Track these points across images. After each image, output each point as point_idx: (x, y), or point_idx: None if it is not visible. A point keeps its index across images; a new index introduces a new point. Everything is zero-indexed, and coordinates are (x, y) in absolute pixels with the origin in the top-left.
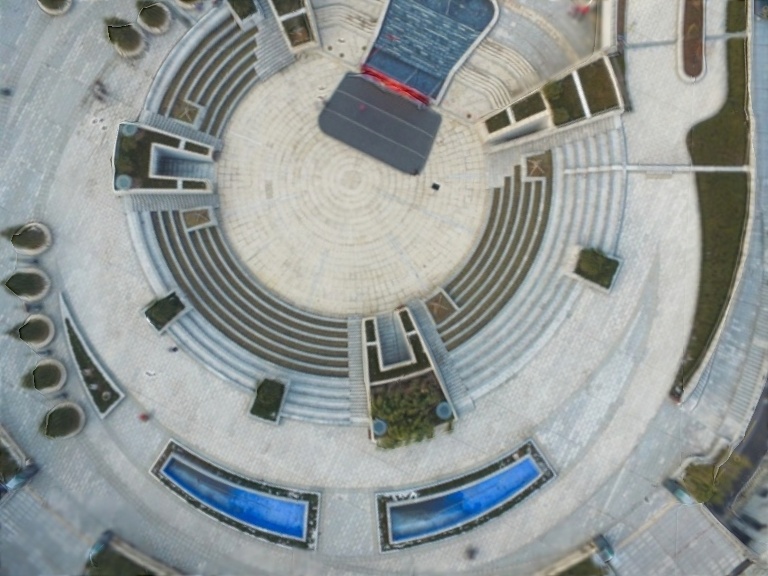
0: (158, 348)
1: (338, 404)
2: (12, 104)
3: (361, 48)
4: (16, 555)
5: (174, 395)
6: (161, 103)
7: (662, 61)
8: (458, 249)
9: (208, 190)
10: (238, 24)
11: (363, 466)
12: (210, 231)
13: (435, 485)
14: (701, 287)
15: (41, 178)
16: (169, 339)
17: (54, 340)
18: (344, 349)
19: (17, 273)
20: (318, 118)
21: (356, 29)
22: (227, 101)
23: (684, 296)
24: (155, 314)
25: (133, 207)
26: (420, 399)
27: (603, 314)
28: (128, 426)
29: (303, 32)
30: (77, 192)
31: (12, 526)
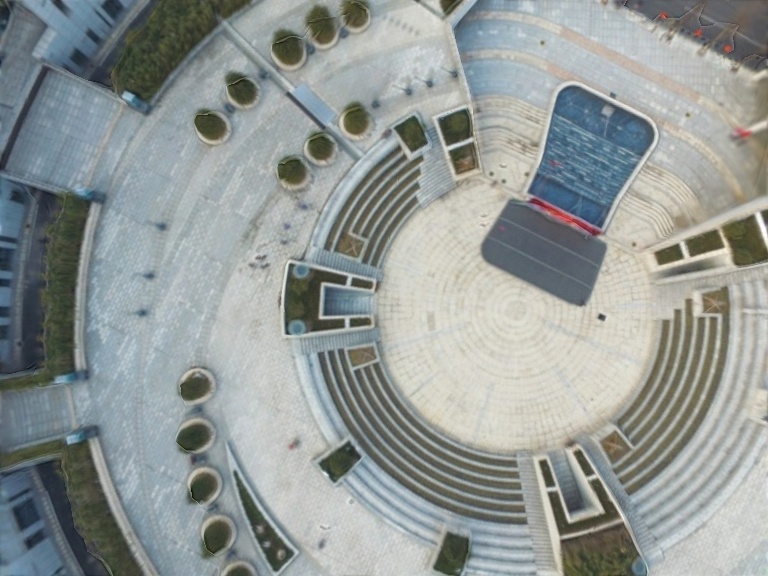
0: (332, 500)
1: (522, 556)
2: (168, 239)
3: (523, 174)
4: None
5: (350, 550)
6: (327, 238)
7: None
8: (626, 382)
9: (372, 325)
10: (405, 155)
11: None
12: (374, 367)
13: None
14: None
15: (201, 319)
16: (345, 491)
17: (221, 494)
18: (518, 491)
19: (186, 427)
20: (481, 247)
21: (518, 154)
22: (388, 230)
23: None
24: (334, 468)
25: (302, 350)
26: (620, 559)
27: None
28: None
29: (469, 161)
30: (241, 333)
31: None
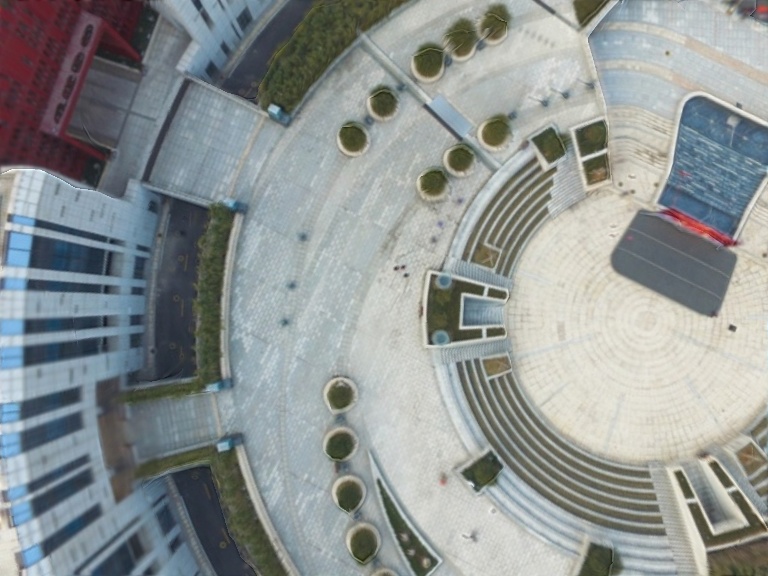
0: (474, 509)
1: (664, 567)
2: (309, 249)
3: (653, 185)
4: None
5: (493, 559)
6: (465, 249)
7: None
8: (758, 393)
9: (505, 335)
10: (541, 166)
11: None
12: (506, 377)
13: None
14: None
15: (342, 328)
16: (487, 500)
17: (365, 502)
18: (654, 502)
19: (333, 435)
20: (611, 257)
21: (647, 165)
22: (520, 241)
23: None
24: (480, 478)
25: (442, 360)
26: None
27: None
28: None
29: (602, 172)
30: (381, 343)
31: None
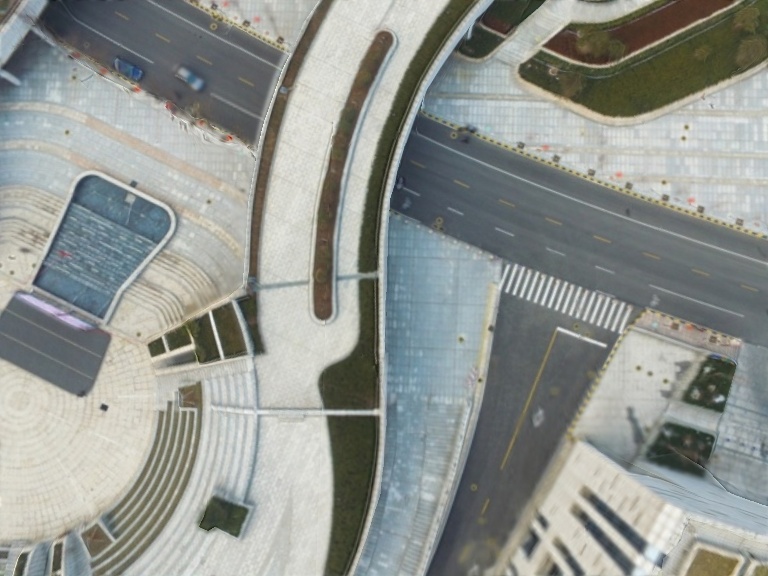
0: None
1: None
2: None
3: (31, 265)
4: None
5: None
6: None
7: (295, 302)
8: (125, 472)
9: None
10: None
11: None
12: None
13: None
14: (332, 533)
15: None
16: None
17: None
18: None
19: None
20: None
21: (27, 245)
22: None
23: (316, 542)
24: None
25: None
26: None
27: (236, 561)
28: None
29: None
30: None
31: None
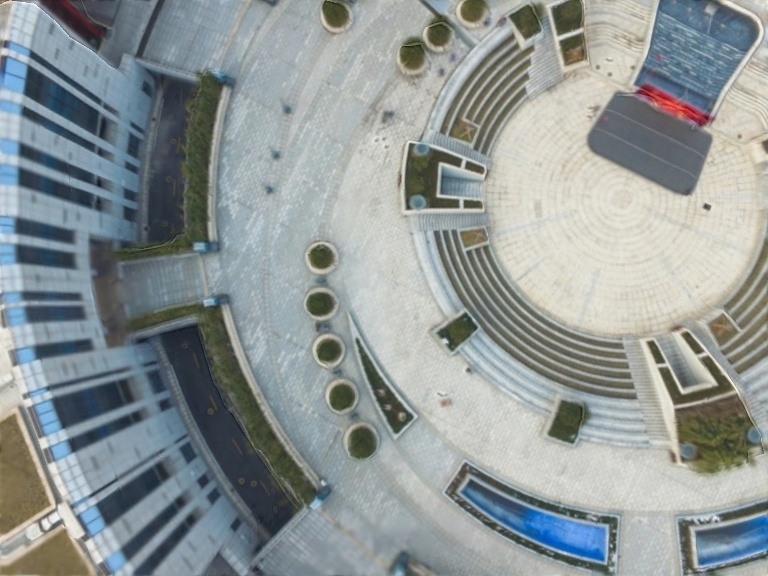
0: (449, 368)
1: (634, 426)
2: (293, 122)
3: (630, 67)
4: (308, 575)
5: (466, 416)
6: (443, 122)
7: None
8: (731, 270)
9: (483, 209)
10: (518, 43)
11: (663, 489)
12: (484, 250)
13: (738, 509)
14: None
15: (324, 197)
16: (461, 360)
17: (344, 360)
18: (626, 370)
19: (313, 293)
20: (587, 137)
21: (624, 48)
22: (498, 120)
23: None
24: (454, 335)
25: (420, 226)
26: (738, 423)
27: None
28: (420, 447)
29: (579, 51)
30: (361, 211)
31: (304, 546)
